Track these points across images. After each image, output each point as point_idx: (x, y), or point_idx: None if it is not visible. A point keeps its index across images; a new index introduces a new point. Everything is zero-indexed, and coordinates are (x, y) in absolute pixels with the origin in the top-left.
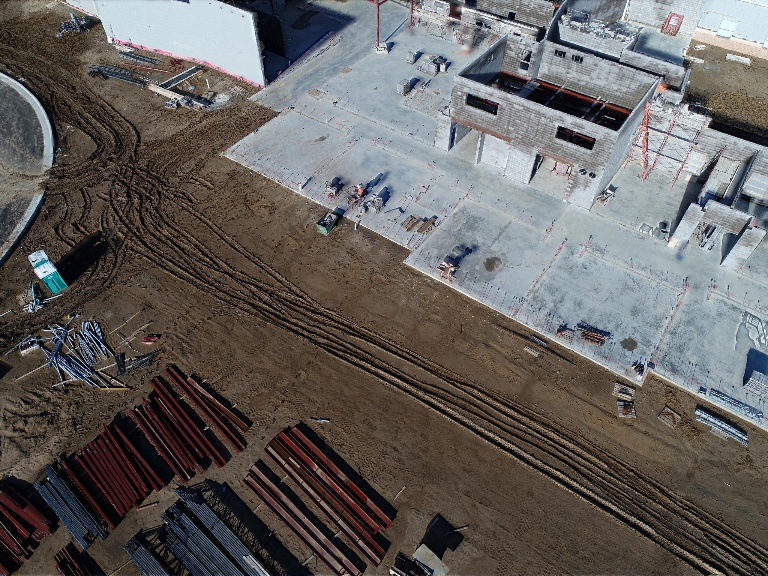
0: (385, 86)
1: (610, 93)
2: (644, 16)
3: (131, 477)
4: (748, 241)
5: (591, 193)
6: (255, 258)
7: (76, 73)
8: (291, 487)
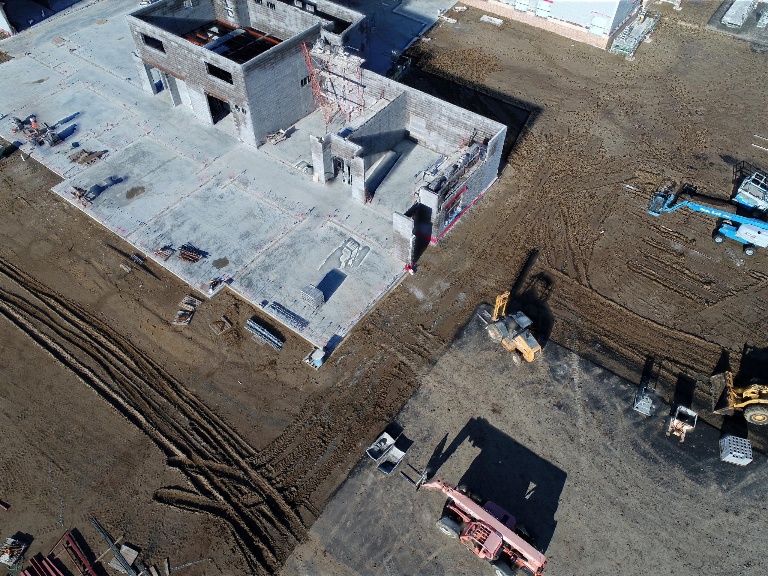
0: (131, 36)
1: None
2: None
3: None
4: (357, 171)
5: (251, 130)
6: None
7: None
8: None
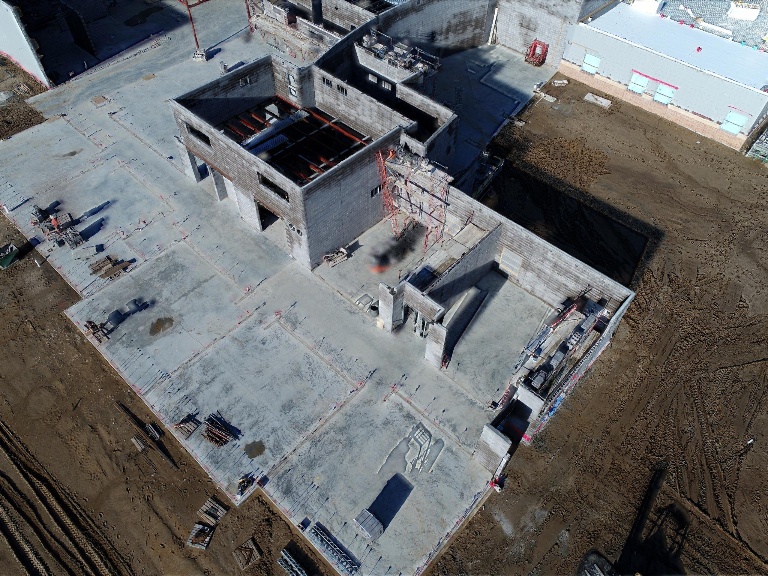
0: None
1: (377, 133)
2: (512, 41)
3: None
4: (435, 337)
5: (306, 252)
6: None
7: None
8: None
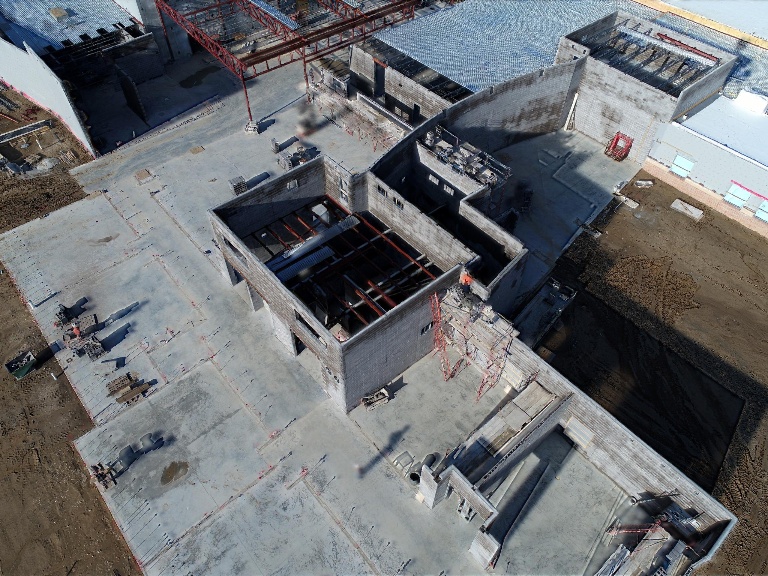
0: (225, 178)
1: (433, 254)
2: (591, 129)
3: None
4: (484, 543)
5: (342, 397)
6: None
7: None
8: None
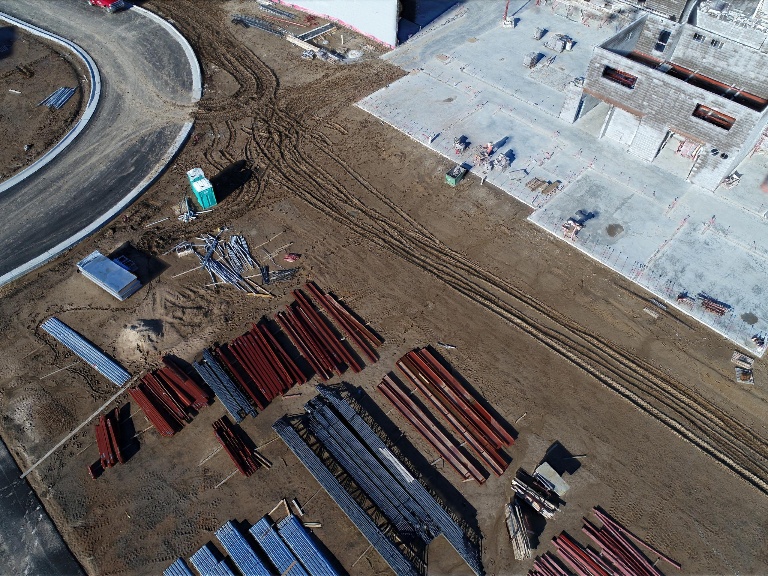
0: (511, 58)
1: (746, 81)
2: None
3: (278, 369)
4: None
5: (719, 174)
6: (386, 199)
7: (220, 20)
8: (420, 399)
